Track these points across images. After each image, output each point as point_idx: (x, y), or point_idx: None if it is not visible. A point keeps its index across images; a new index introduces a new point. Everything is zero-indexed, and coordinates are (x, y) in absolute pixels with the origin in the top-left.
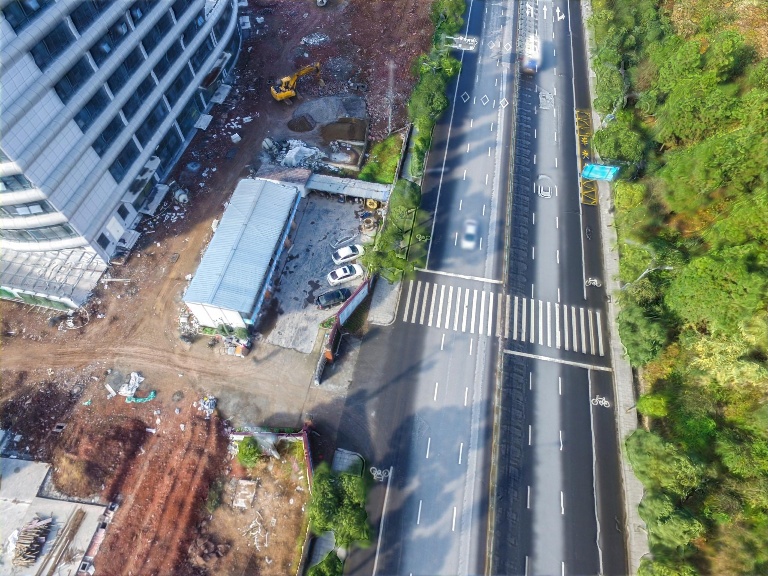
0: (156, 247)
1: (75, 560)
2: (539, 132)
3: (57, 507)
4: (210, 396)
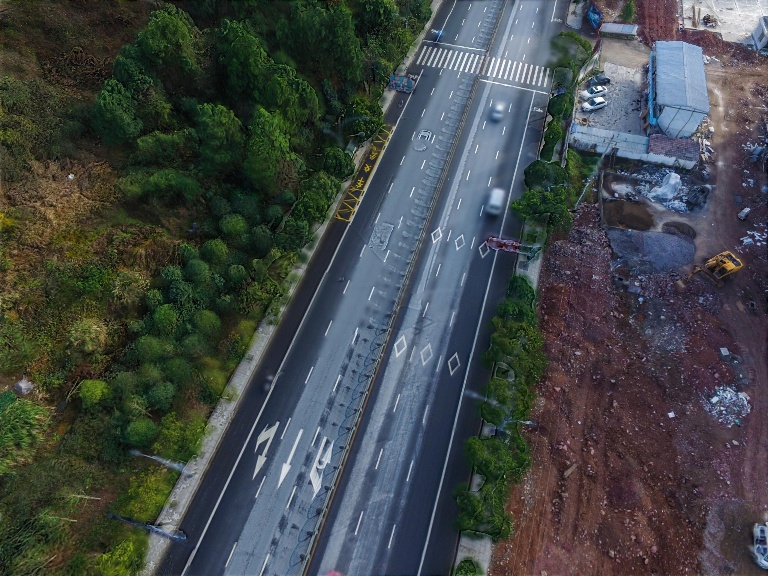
0: (748, 126)
1: (687, 17)
2: (407, 194)
3: (708, 29)
4: None
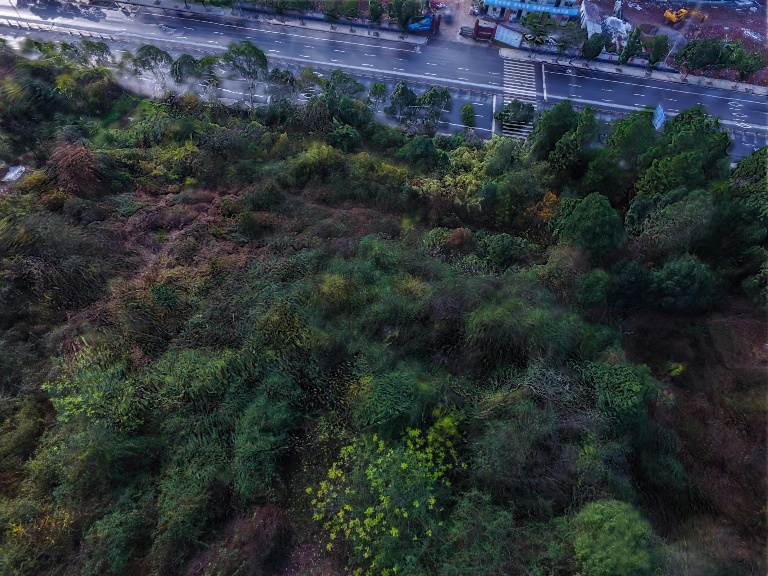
0: None
1: None
2: None
3: None
4: (447, 6)
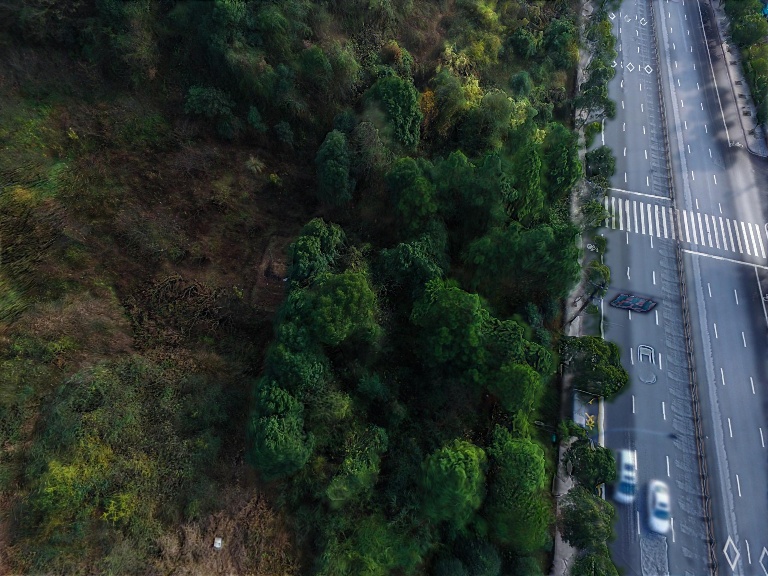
0: None
1: None
2: (662, 471)
3: None
4: None
